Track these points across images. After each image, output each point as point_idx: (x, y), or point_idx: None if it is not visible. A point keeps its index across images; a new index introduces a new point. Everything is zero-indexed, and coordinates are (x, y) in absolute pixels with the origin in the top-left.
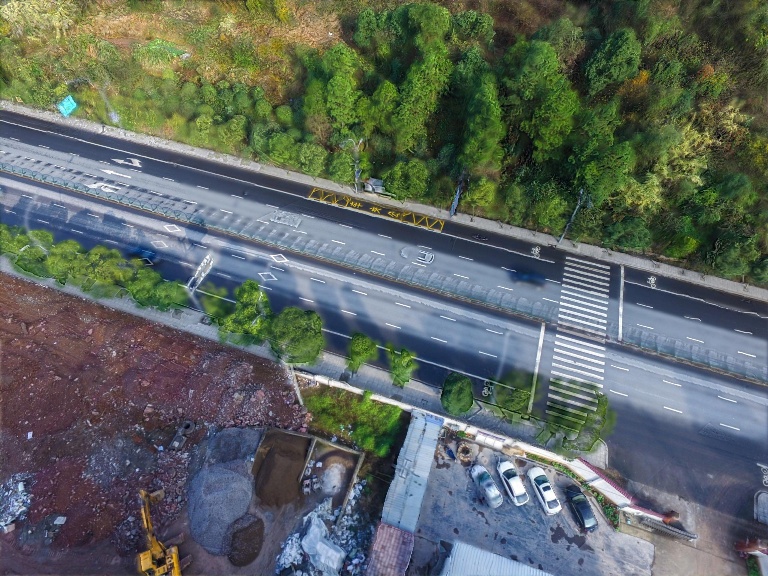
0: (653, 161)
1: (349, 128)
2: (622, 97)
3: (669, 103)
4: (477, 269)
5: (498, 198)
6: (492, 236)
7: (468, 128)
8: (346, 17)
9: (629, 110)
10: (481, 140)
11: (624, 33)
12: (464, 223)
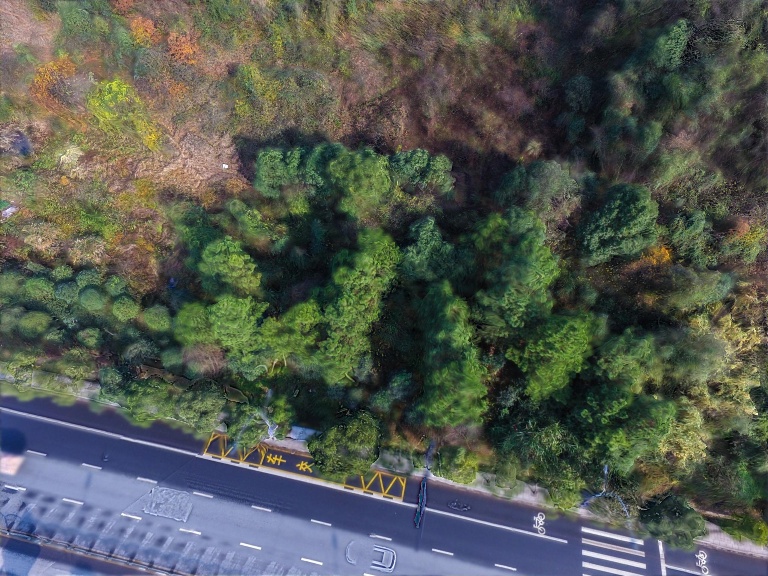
0: (690, 382)
1: (255, 353)
2: (636, 275)
3: (705, 295)
4: (460, 574)
5: (480, 441)
6: (476, 500)
7: (432, 373)
8: (245, 144)
9: (646, 293)
10: (454, 401)
11: (639, 199)
12: (434, 478)
